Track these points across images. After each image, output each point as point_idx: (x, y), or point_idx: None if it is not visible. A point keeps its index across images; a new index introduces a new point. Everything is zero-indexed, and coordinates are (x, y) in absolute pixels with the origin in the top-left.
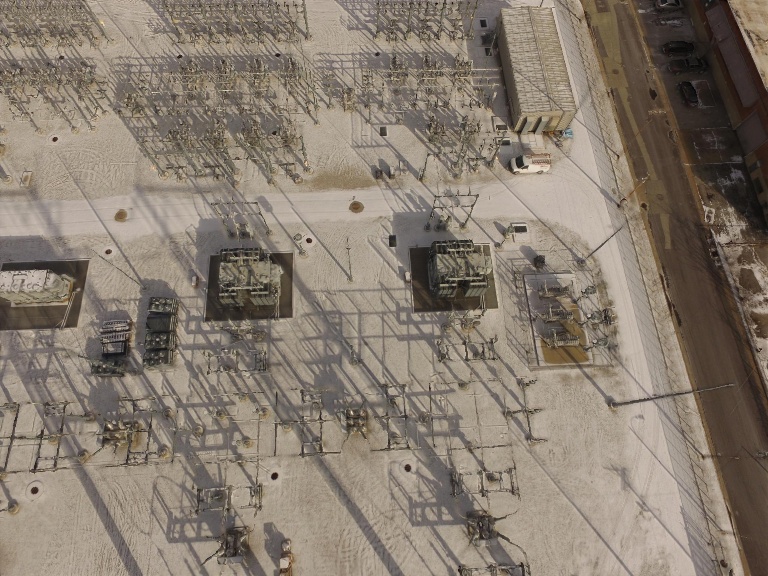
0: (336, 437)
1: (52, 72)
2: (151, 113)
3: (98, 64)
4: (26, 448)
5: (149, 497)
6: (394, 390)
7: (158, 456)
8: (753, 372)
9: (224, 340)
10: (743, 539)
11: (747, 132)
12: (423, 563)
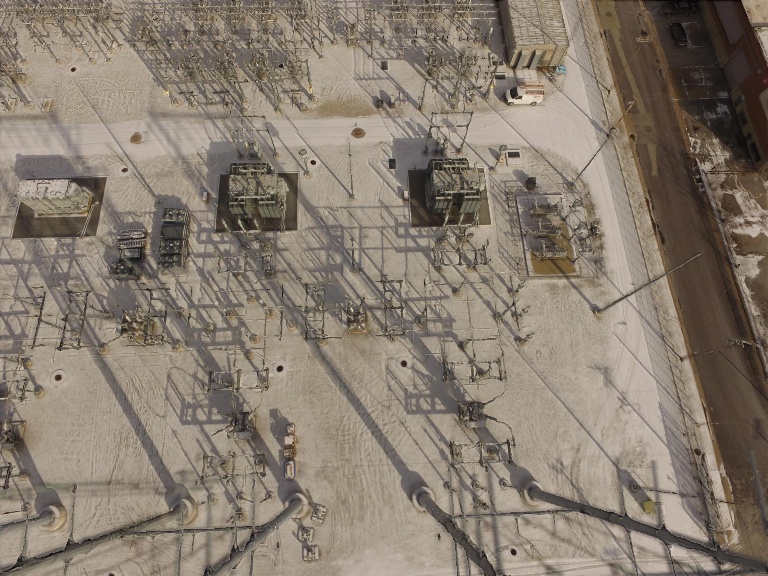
0: (337, 336)
1: (70, 7)
2: (164, 47)
3: (113, 2)
4: (50, 341)
5: (164, 385)
6: (392, 296)
7: (172, 349)
8: (731, 286)
9: (233, 249)
10: (717, 431)
11: (733, 68)
12: (417, 446)
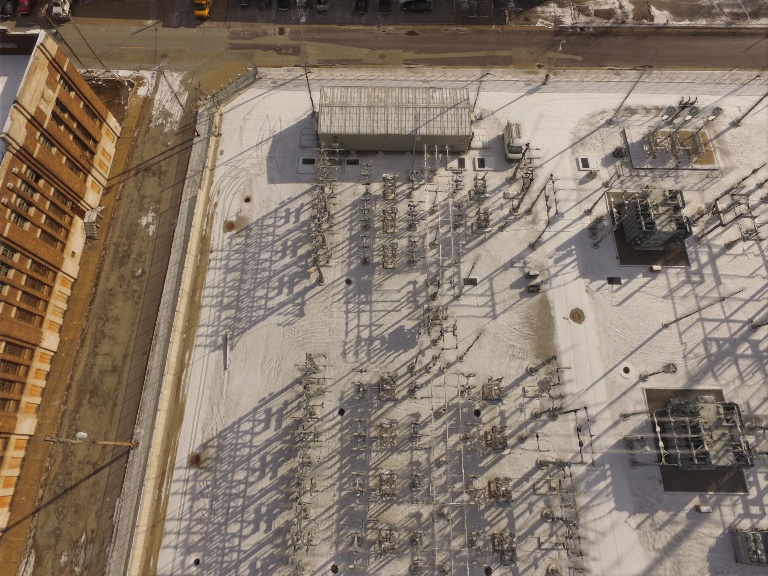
0: None
1: None
2: None
3: None
4: None
5: None
6: None
7: None
8: (683, 31)
9: (763, 468)
10: None
11: None
12: None
